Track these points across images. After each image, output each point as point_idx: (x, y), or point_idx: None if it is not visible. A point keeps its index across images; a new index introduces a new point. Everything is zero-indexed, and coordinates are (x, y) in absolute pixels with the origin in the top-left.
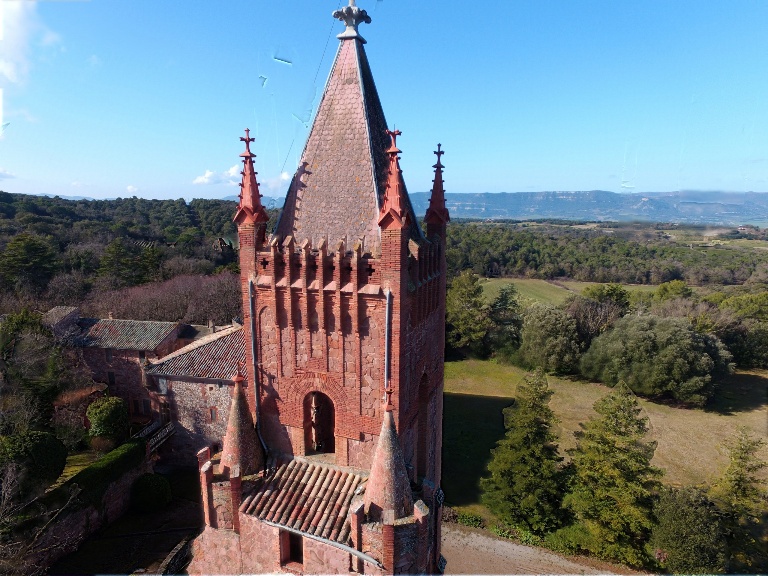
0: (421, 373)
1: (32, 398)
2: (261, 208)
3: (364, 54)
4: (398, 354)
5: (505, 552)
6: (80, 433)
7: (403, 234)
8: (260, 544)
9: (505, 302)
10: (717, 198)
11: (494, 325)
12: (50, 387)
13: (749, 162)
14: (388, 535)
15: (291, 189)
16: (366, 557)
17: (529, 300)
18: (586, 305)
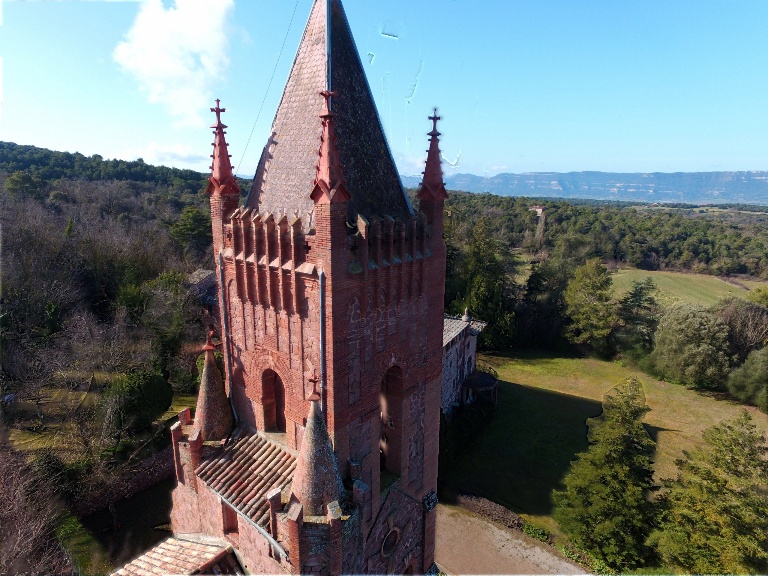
0: (387, 365)
1: (156, 344)
2: (229, 180)
3: (341, 10)
4: (331, 341)
5: None
6: (187, 379)
7: (336, 209)
8: (210, 508)
9: (639, 298)
10: None
11: (622, 323)
12: (171, 337)
13: None
14: (293, 530)
15: (261, 160)
16: (278, 547)
17: (670, 298)
18: (747, 310)
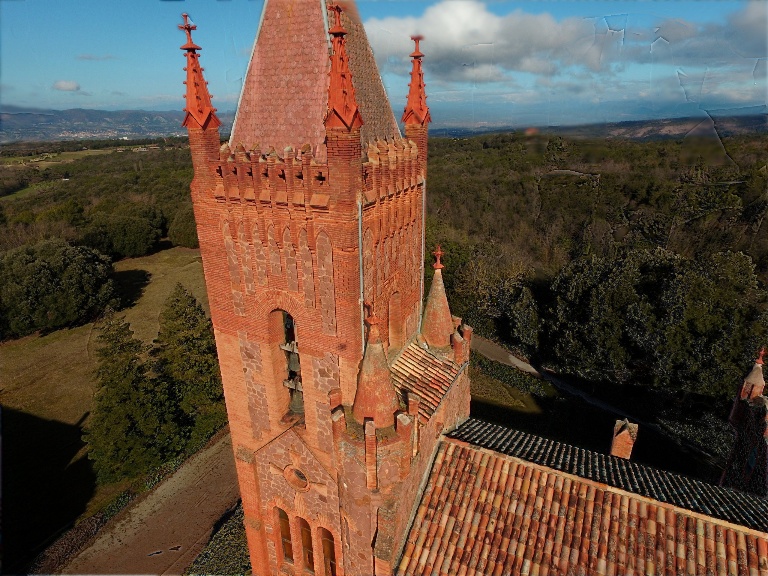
0: None
1: None
2: None
3: None
4: None
5: (173, 489)
6: None
7: None
8: None
9: None
10: (27, 108)
11: None
12: None
13: (42, 70)
14: None
15: None
16: None
17: None
18: None
